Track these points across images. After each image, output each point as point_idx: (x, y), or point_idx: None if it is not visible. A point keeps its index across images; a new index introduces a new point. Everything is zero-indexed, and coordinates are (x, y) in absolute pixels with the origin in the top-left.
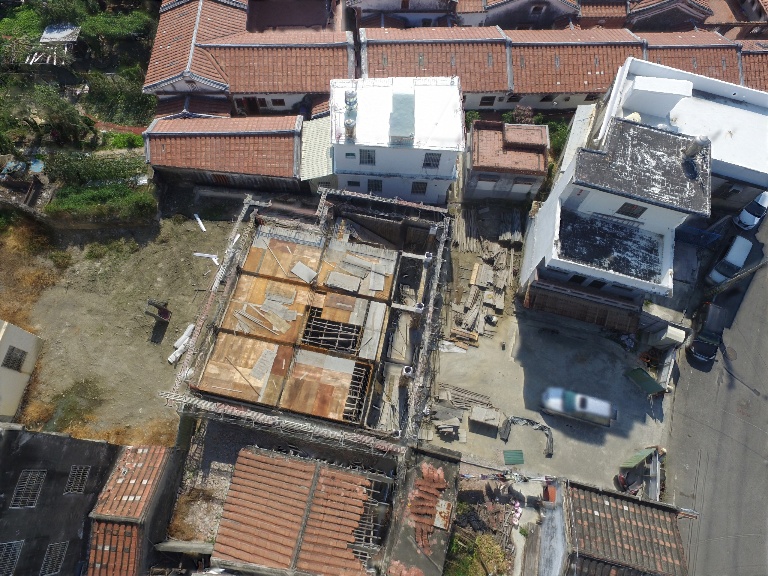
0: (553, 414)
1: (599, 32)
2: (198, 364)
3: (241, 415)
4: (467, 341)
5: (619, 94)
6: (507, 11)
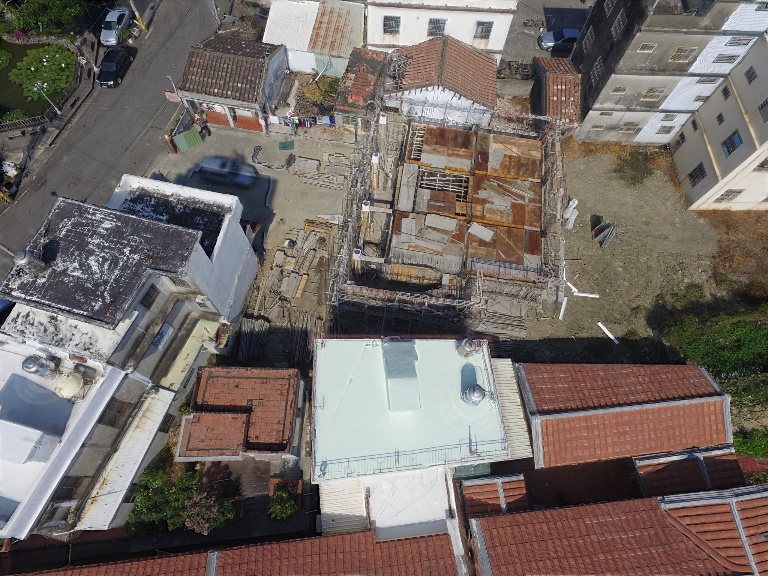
0: (248, 173)
1: None
2: (549, 163)
3: (503, 129)
4: (316, 223)
5: (64, 439)
6: None
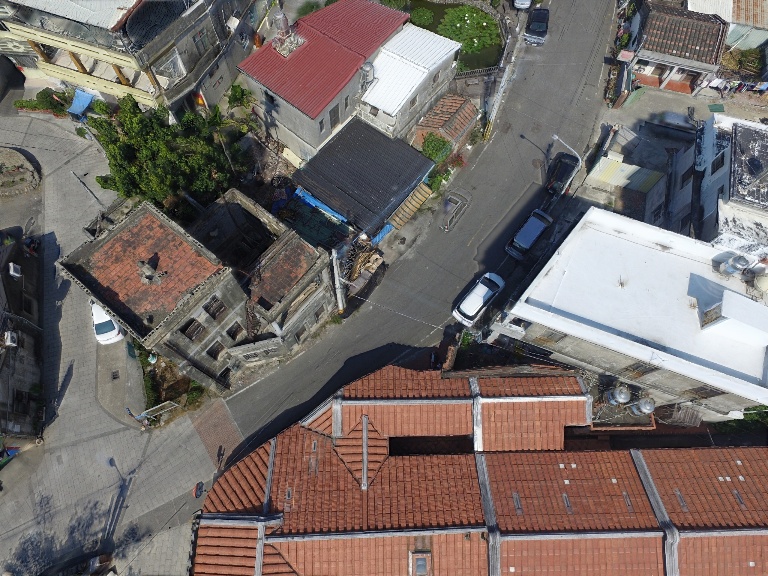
0: (690, 130)
1: None
2: None
3: None
4: None
5: None
6: None
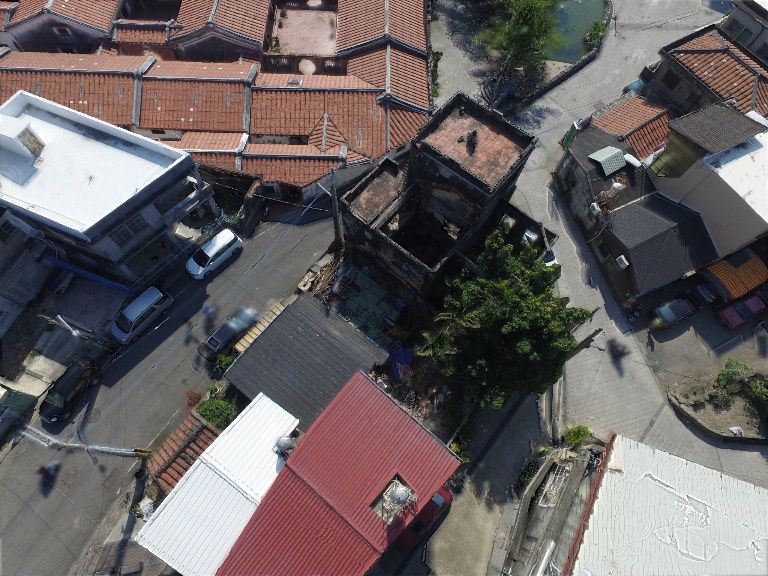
0: None
1: (114, 59)
2: None
3: None
4: None
5: None
6: (30, 32)
